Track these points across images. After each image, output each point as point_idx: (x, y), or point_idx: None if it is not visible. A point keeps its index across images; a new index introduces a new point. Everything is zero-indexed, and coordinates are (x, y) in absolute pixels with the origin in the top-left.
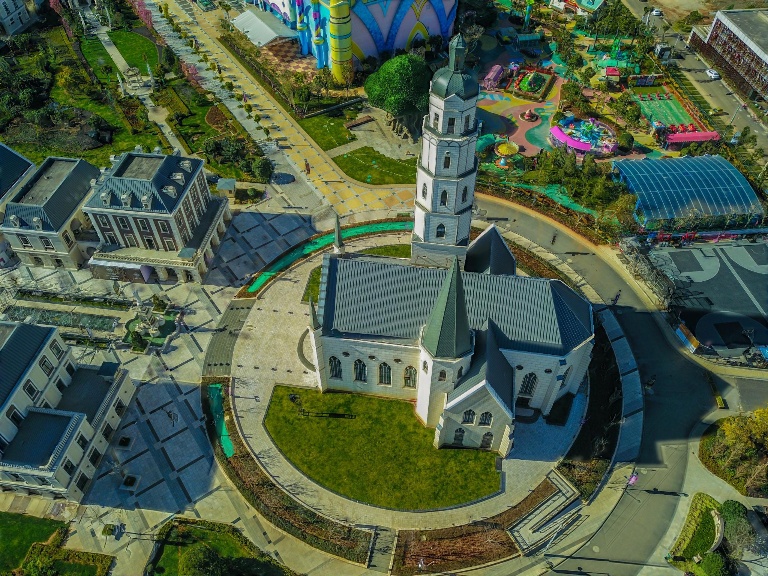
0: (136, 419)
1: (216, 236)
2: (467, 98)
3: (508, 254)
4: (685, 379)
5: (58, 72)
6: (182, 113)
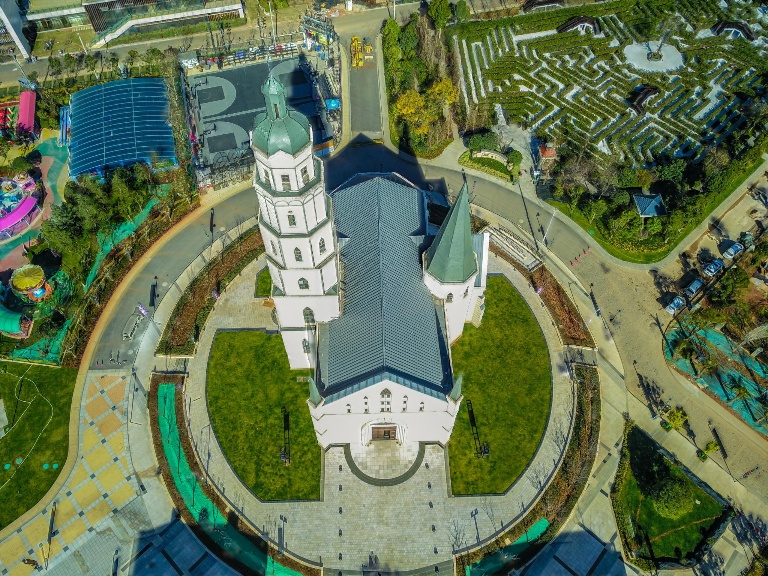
0: None
1: None
2: None
3: None
4: (359, 159)
5: None
6: None
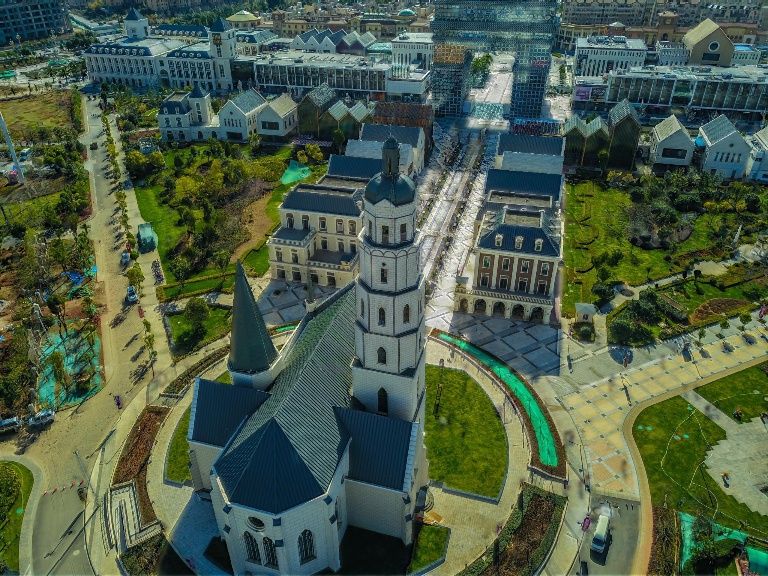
0: (325, 292)
1: (508, 309)
2: (368, 198)
3: (403, 471)
4: None
5: (754, 211)
6: (719, 281)
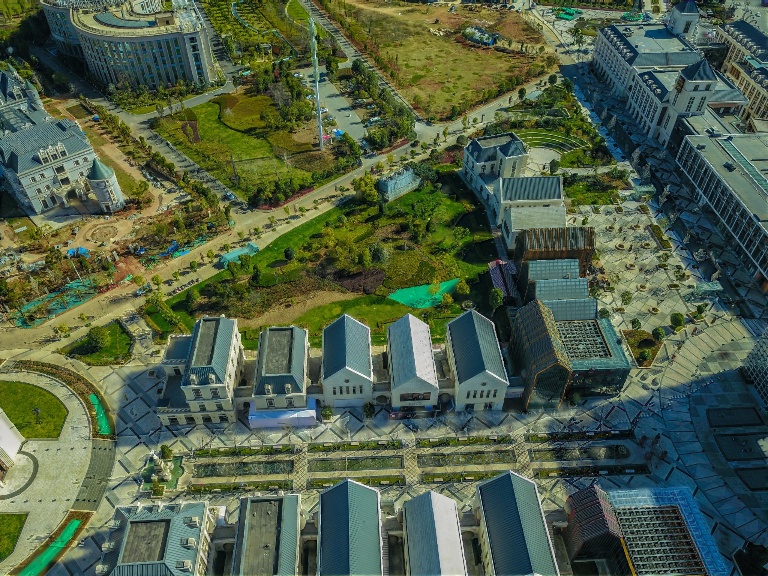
0: None
1: None
2: None
3: None
4: None
5: None
6: None
